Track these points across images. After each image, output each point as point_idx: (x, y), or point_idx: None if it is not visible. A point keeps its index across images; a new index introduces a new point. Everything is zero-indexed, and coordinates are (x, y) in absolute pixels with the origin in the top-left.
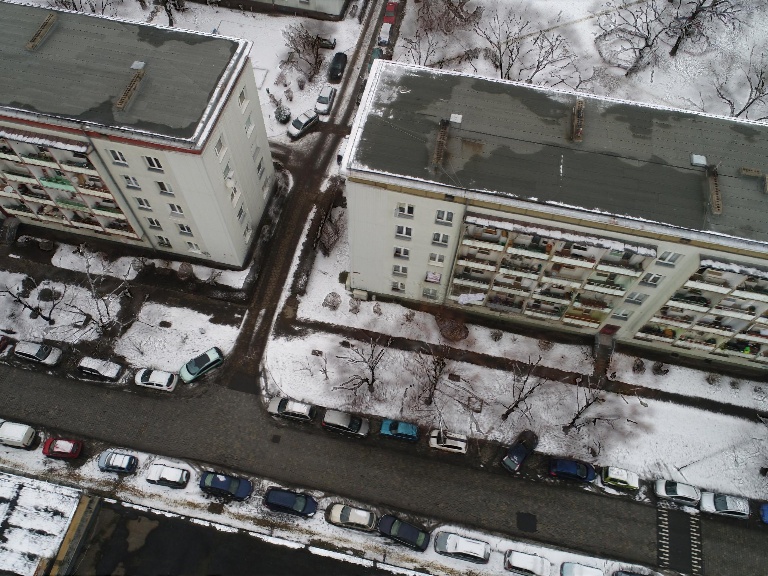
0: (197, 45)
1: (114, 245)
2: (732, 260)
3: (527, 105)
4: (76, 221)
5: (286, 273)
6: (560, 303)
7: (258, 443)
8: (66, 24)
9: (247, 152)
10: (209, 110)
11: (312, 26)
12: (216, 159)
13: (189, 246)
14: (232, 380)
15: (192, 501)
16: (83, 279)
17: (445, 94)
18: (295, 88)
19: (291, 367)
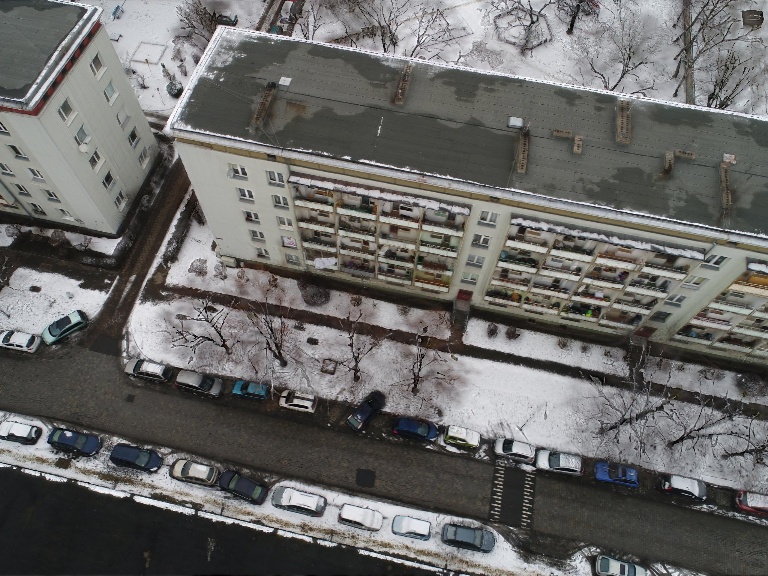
0: (46, 11)
1: None
2: (542, 219)
3: (358, 70)
4: None
5: (161, 241)
6: (405, 266)
7: (112, 402)
8: None
9: (110, 119)
10: (45, 72)
11: (216, 4)
12: (62, 122)
13: (63, 213)
14: (95, 342)
15: (41, 456)
16: None
17: (280, 59)
18: (191, 63)
19: (154, 330)
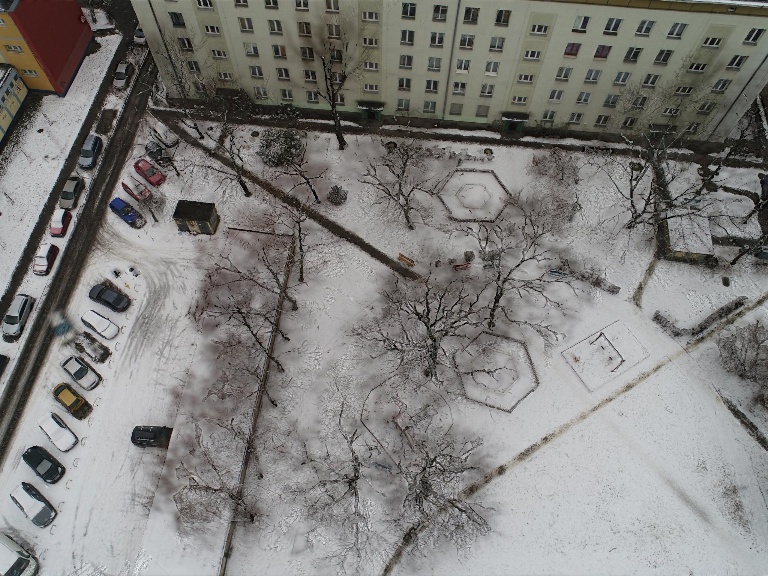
0: None
1: None
2: None
3: None
4: None
5: None
6: None
7: None
8: None
9: None
10: None
11: None
12: None
13: None
14: None
15: None
16: None
17: None
18: None
19: None
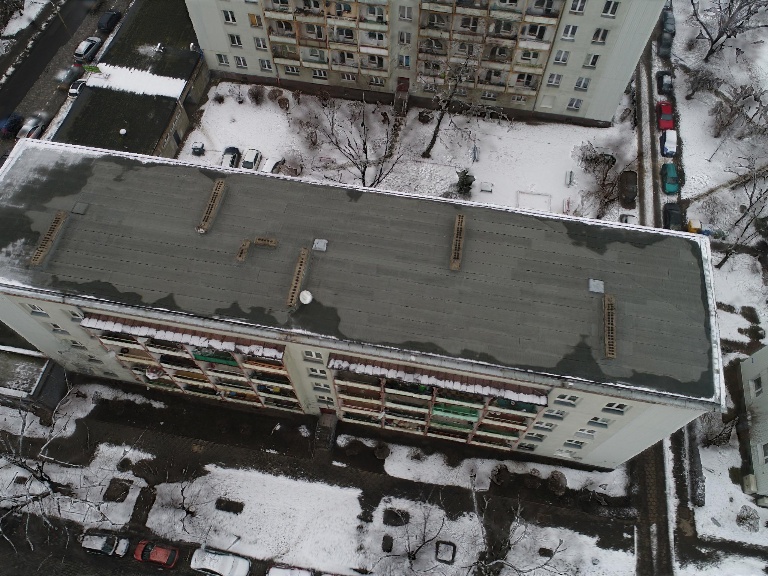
0: (649, 248)
1: (451, 443)
2: None
3: None
4: (435, 433)
5: (662, 471)
6: None
7: None
8: (474, 224)
9: None
10: (717, 352)
11: (581, 135)
12: None
13: None
14: None
15: None
16: (429, 493)
17: None
18: None
19: None
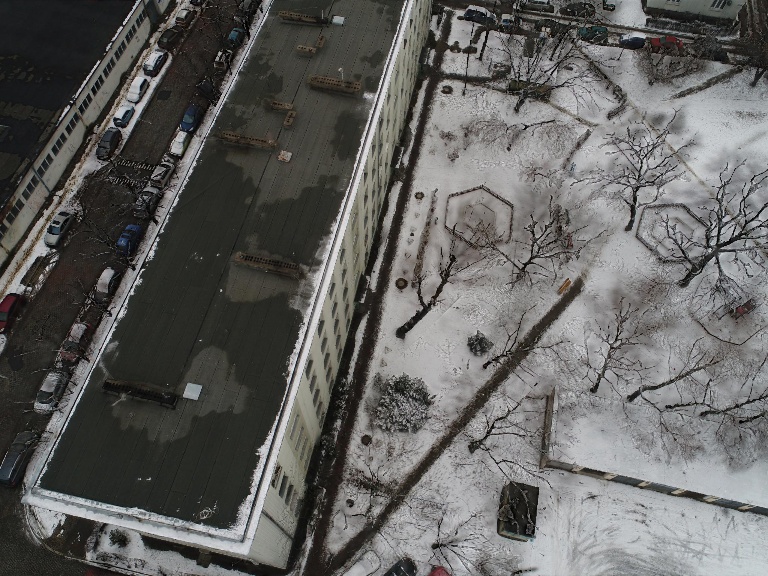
0: None
1: None
2: None
3: None
4: None
5: None
6: None
7: None
8: None
9: None
10: None
11: None
12: None
13: None
14: None
15: None
16: None
17: None
18: None
19: None
